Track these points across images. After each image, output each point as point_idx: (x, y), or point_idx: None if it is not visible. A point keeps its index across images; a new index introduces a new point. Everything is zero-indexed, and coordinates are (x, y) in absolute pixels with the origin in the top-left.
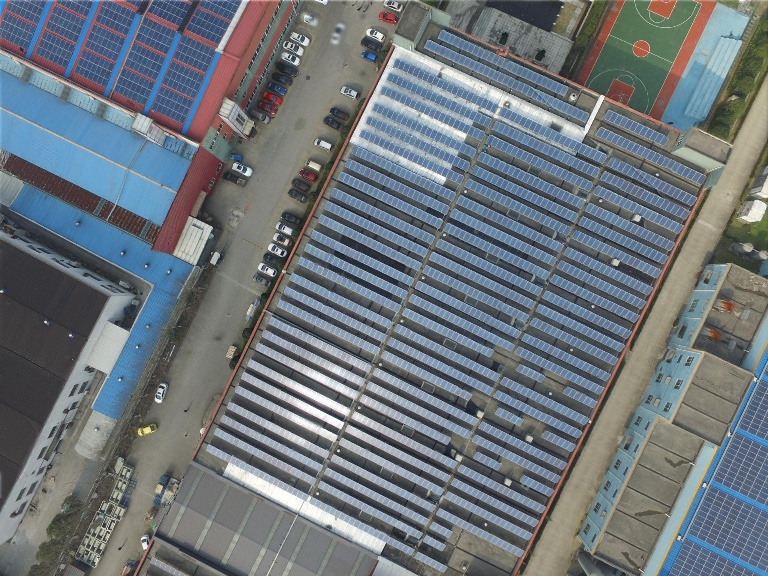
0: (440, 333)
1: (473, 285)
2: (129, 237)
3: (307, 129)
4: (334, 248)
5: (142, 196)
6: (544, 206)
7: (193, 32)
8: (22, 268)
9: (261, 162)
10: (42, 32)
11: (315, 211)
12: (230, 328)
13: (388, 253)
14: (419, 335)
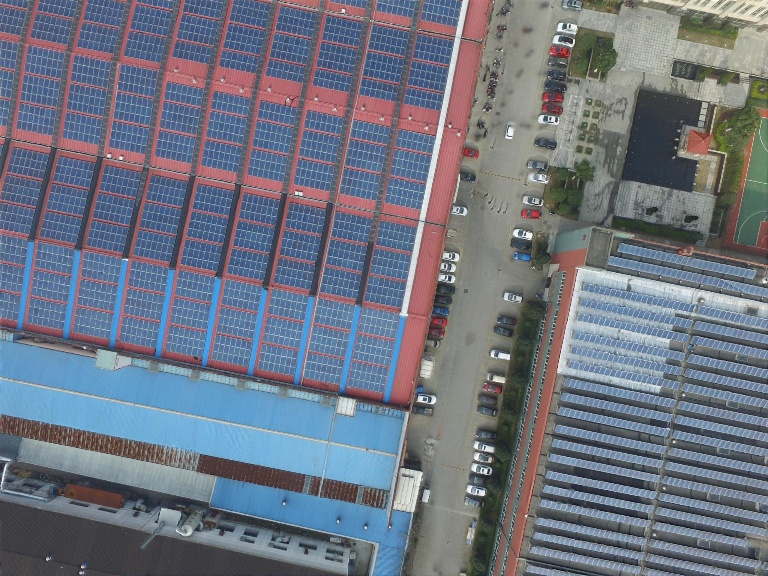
0: (693, 536)
1: (712, 481)
2: (339, 502)
3: (478, 342)
4: (571, 482)
5: (348, 464)
6: (761, 390)
7: (372, 301)
8: (253, 574)
9: (441, 385)
10: (213, 336)
11: (541, 449)
12: (453, 556)
13: (625, 473)
14: (675, 545)
